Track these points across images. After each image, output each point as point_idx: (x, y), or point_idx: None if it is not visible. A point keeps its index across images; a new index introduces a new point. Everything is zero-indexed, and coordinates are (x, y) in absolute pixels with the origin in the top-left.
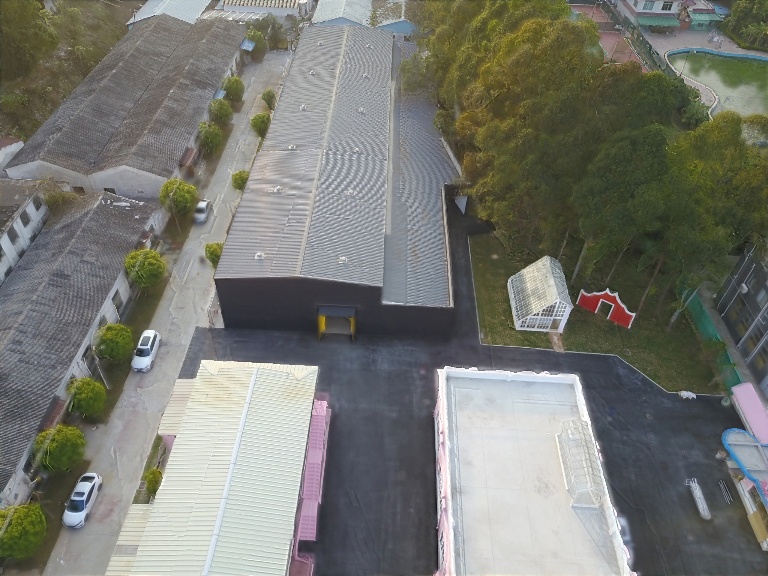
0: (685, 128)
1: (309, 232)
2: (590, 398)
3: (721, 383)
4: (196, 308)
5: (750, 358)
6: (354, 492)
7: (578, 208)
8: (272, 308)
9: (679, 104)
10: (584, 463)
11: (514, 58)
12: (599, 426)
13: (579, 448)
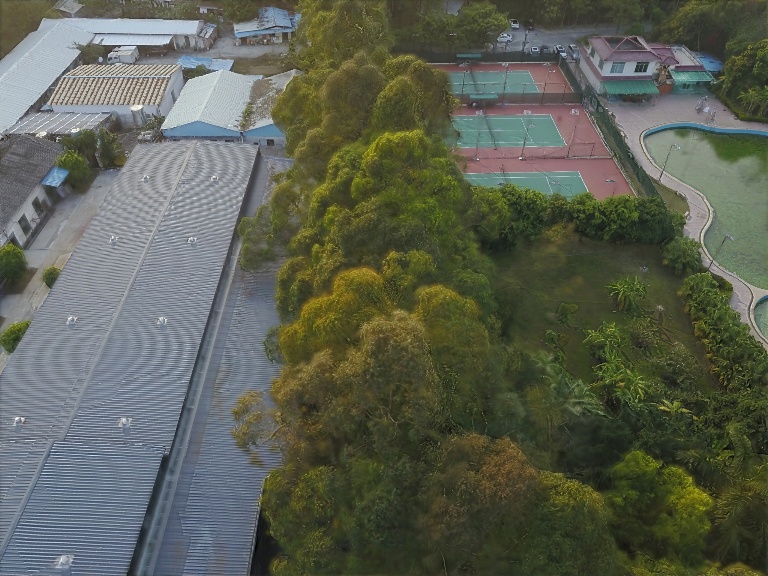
0: (668, 272)
1: None
2: None
3: None
4: None
5: None
6: None
7: None
8: None
9: (658, 238)
10: None
11: (294, 387)
12: None
13: None
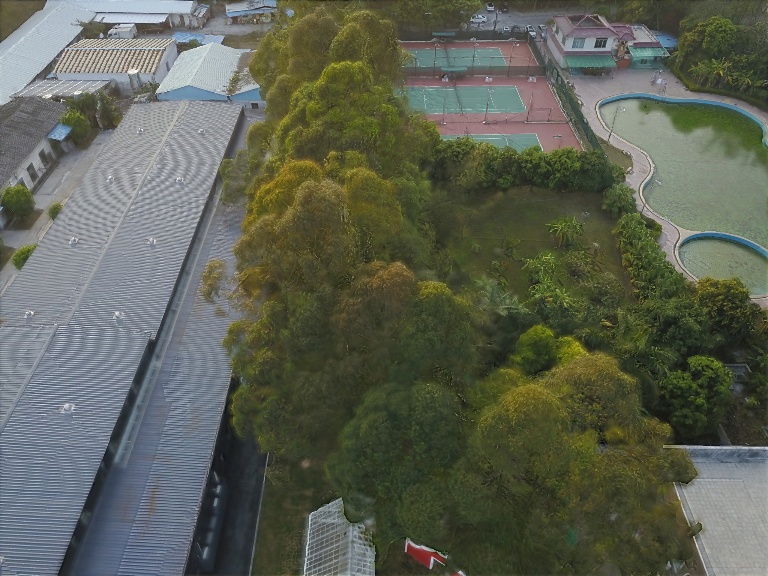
0: (607, 216)
1: None
2: None
3: None
4: None
5: None
6: None
7: None
8: None
9: (598, 186)
10: None
11: (244, 238)
12: None
13: None
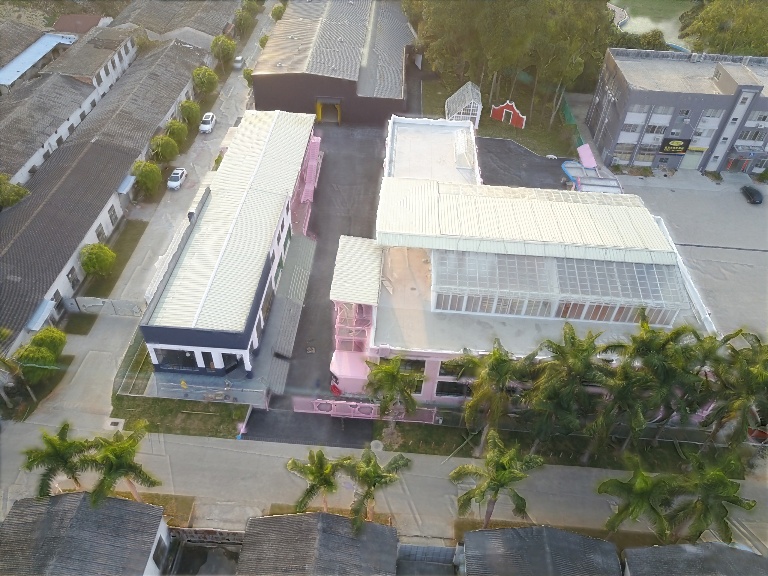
0: None
1: (312, 55)
2: (489, 157)
3: (574, 151)
4: (237, 109)
5: (598, 142)
6: (336, 185)
7: (479, 30)
8: (287, 100)
9: None
10: (464, 144)
11: None
12: (491, 168)
13: (462, 139)
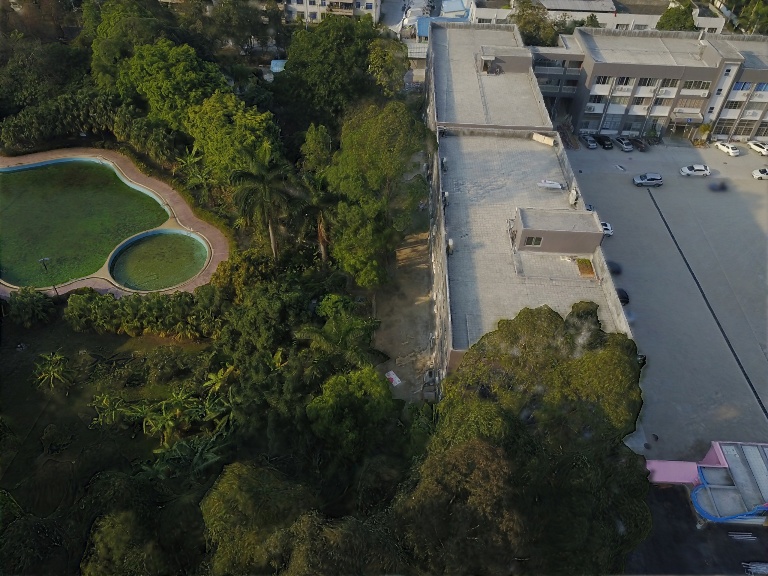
0: (39, 328)
1: None
2: None
3: None
4: None
5: None
6: None
7: None
8: None
9: None
10: None
11: None
12: None
13: None
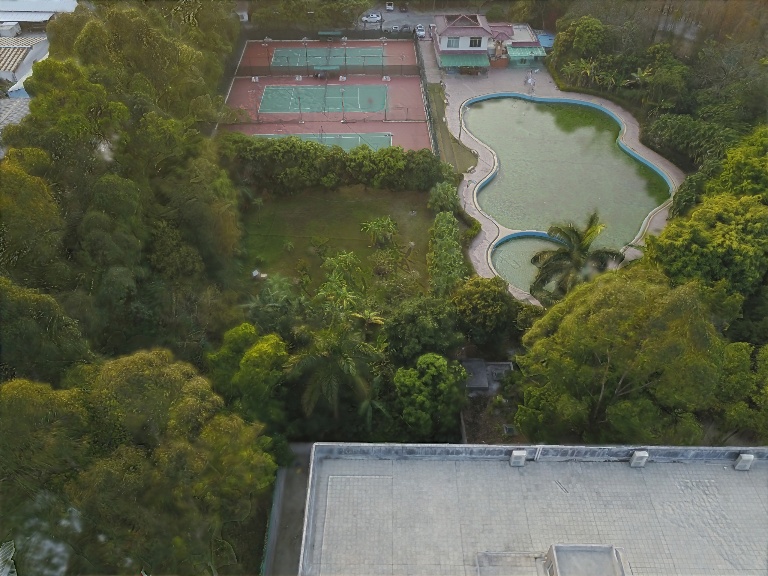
0: (432, 215)
1: None
2: None
3: None
4: None
5: None
6: None
7: None
8: None
9: (425, 185)
10: None
11: None
12: None
13: None
